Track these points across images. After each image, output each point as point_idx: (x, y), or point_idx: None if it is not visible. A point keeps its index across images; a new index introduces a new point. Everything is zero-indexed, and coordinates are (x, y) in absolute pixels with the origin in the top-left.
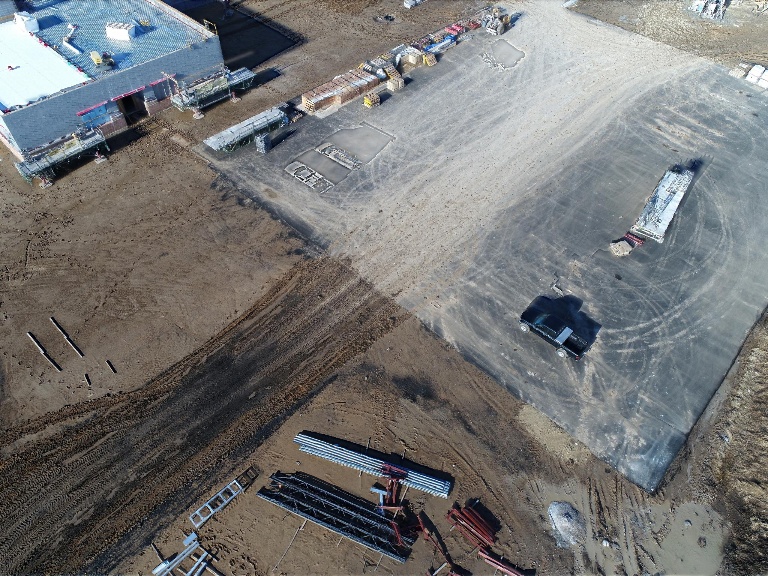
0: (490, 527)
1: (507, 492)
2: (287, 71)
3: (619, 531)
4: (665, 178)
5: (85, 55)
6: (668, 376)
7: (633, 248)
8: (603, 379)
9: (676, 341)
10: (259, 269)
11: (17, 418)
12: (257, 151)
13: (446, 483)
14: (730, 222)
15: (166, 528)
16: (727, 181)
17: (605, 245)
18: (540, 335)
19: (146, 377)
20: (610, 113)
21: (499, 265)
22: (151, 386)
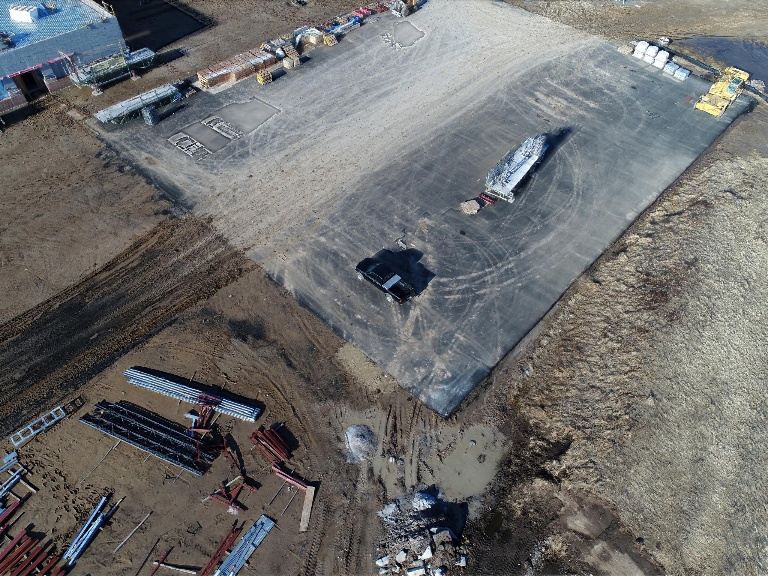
0: (287, 446)
1: (312, 417)
2: (191, 52)
3: (407, 450)
4: (524, 143)
5: None
6: (487, 318)
7: (483, 207)
8: (425, 321)
9: (503, 288)
10: (125, 228)
11: None
12: (145, 124)
13: (255, 409)
14: (583, 184)
15: None
16: (590, 147)
17: (457, 205)
18: (372, 282)
19: None
20: (493, 87)
21: (351, 223)
22: (2, 329)
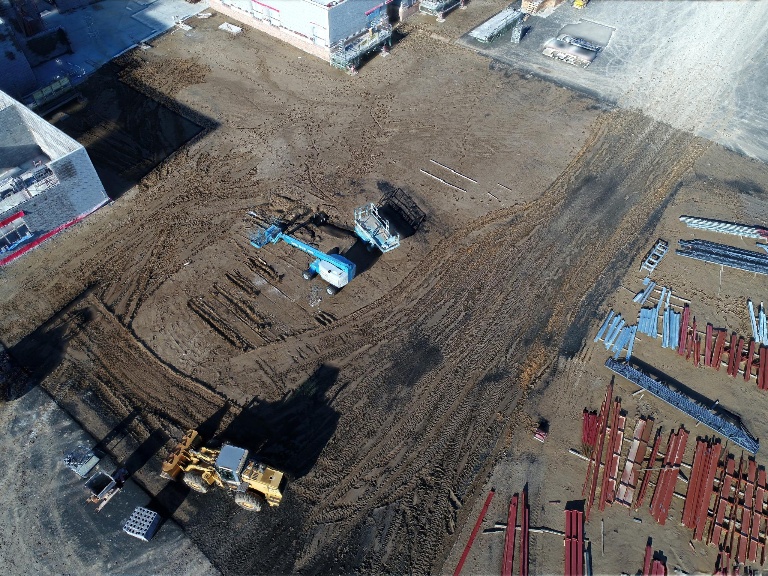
0: None
1: None
2: None
3: None
4: None
5: None
6: None
7: None
8: None
9: None
10: (571, 120)
11: (457, 222)
12: (510, 42)
13: None
14: None
15: (624, 276)
16: None
17: None
18: None
19: (537, 191)
20: None
21: (757, 108)
22: (545, 197)
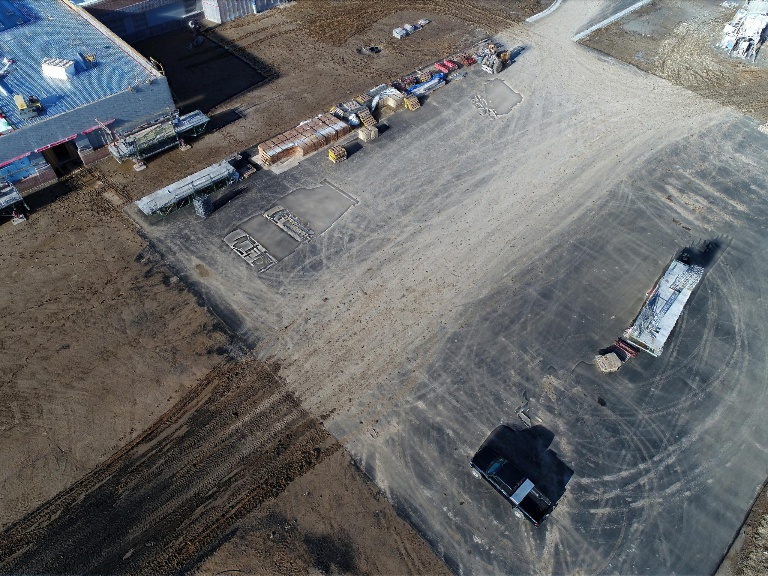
0: None
1: None
2: (250, 113)
3: None
4: (670, 270)
5: (13, 97)
6: (651, 552)
7: (624, 361)
8: (568, 552)
9: (666, 499)
10: (170, 372)
11: None
12: (196, 214)
13: None
14: (747, 328)
15: None
16: (747, 271)
17: (590, 356)
18: (493, 486)
19: (6, 520)
20: (613, 176)
21: (457, 379)
22: (10, 534)
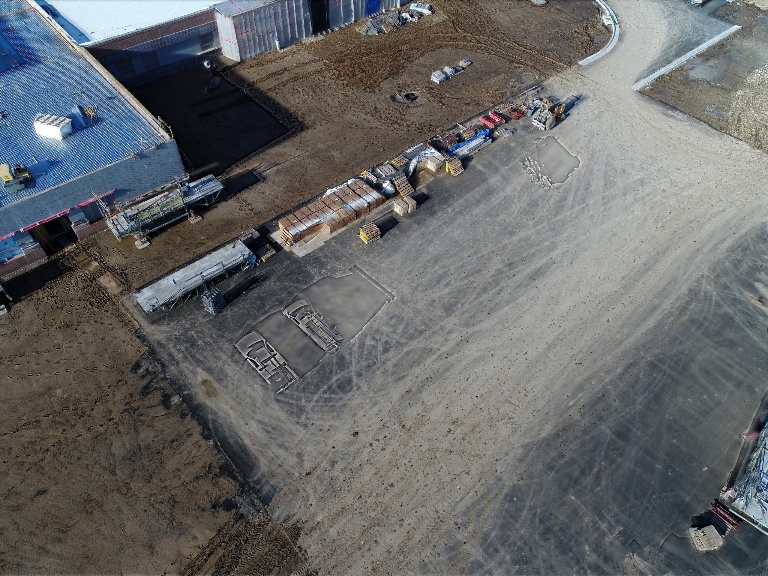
0: None
1: None
2: (269, 175)
3: None
4: None
5: None
6: None
7: (723, 535)
8: None
9: None
10: (166, 535)
11: None
12: (205, 310)
13: None
14: None
15: None
16: None
17: (681, 525)
18: None
19: None
20: (692, 269)
21: (518, 557)
22: None
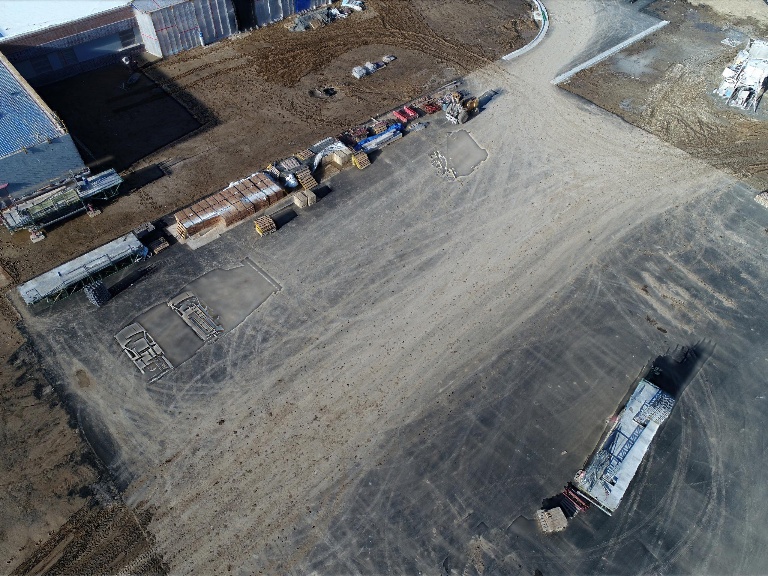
0: None
1: None
2: (175, 169)
3: None
4: (636, 394)
5: None
6: None
7: (572, 517)
8: None
9: None
10: (18, 522)
11: None
12: (90, 302)
13: None
14: (725, 471)
15: None
16: (730, 390)
17: (531, 508)
18: None
19: None
20: (582, 259)
21: (364, 540)
22: None
